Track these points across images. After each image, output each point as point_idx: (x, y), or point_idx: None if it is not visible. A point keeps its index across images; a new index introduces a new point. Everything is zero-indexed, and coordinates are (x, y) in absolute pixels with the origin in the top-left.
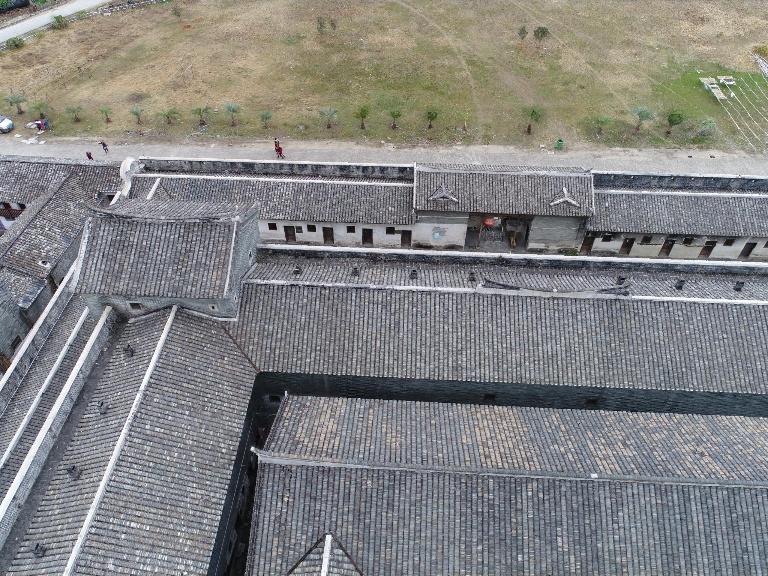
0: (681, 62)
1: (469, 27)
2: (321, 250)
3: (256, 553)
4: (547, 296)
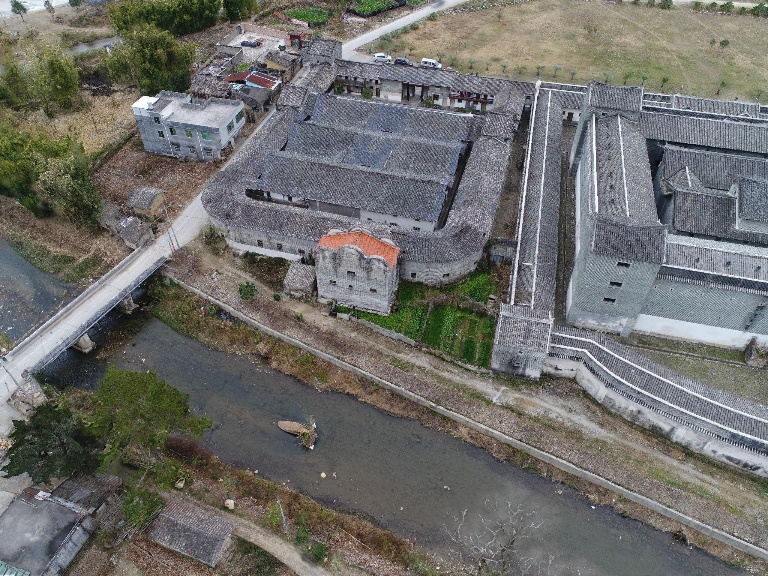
0: None
1: (676, 37)
2: (659, 108)
3: (665, 168)
4: (749, 125)
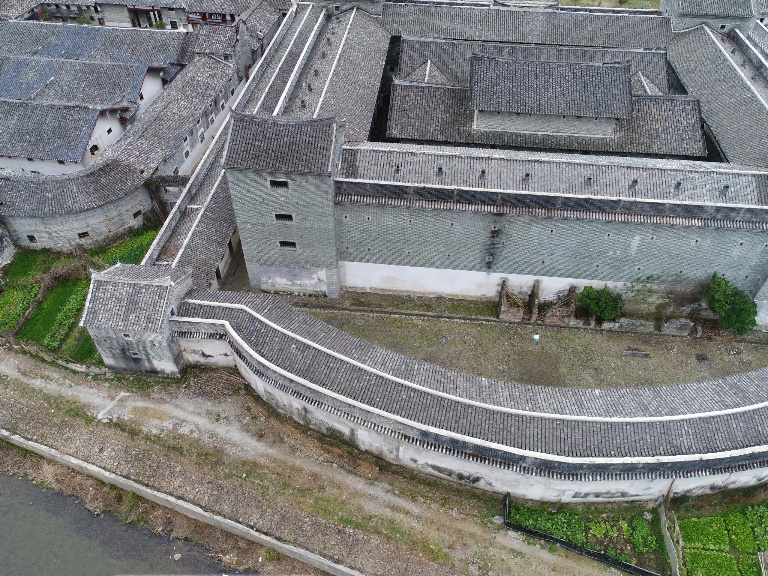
0: None
1: None
2: (416, 0)
3: (402, 65)
4: (522, 11)
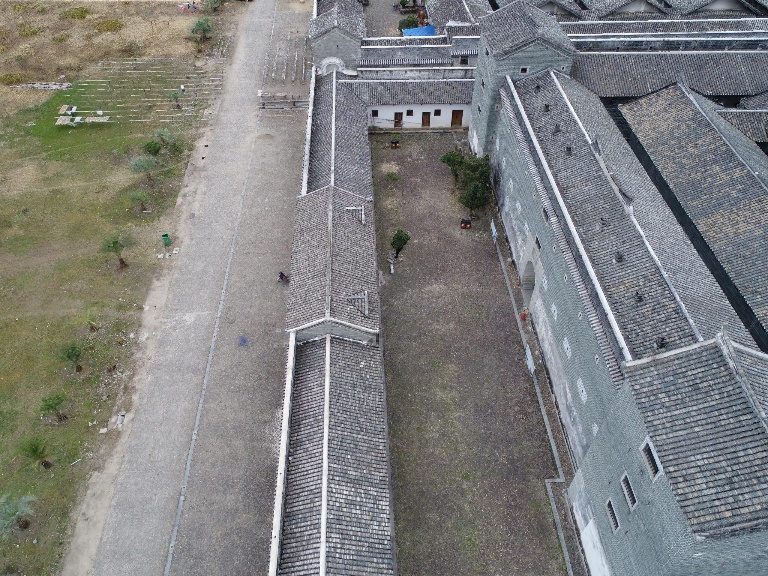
0: (2, 131)
1: None
2: None
3: None
4: None
